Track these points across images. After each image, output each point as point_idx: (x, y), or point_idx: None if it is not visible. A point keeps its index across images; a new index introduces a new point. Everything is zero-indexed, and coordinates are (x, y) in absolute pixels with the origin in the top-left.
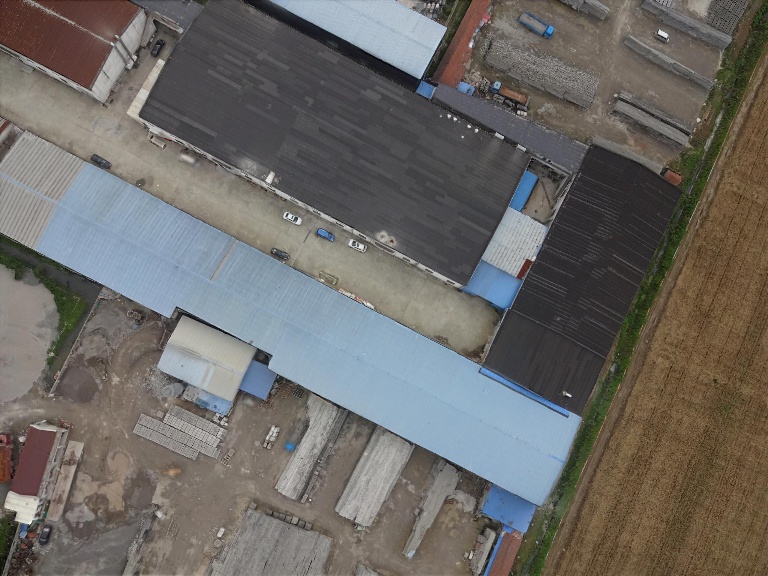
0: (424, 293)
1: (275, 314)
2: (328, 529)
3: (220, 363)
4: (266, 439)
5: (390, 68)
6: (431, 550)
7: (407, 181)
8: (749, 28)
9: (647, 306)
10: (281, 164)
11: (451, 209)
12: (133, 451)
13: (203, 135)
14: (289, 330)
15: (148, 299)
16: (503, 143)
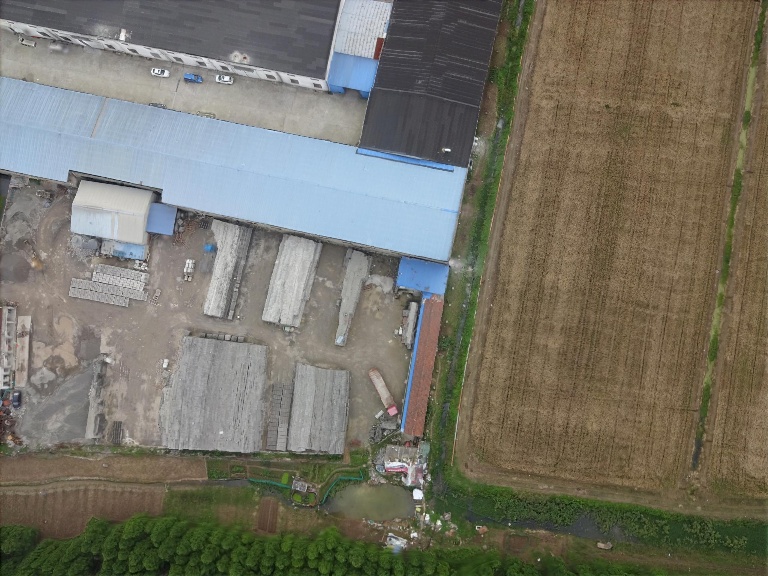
0: (297, 105)
1: (154, 151)
2: (261, 339)
3: (121, 211)
4: (184, 272)
5: None
6: (361, 335)
7: None
8: None
9: (517, 54)
10: (128, 20)
11: (290, 11)
12: (73, 312)
13: (55, 16)
14: (170, 162)
15: (44, 170)
16: None
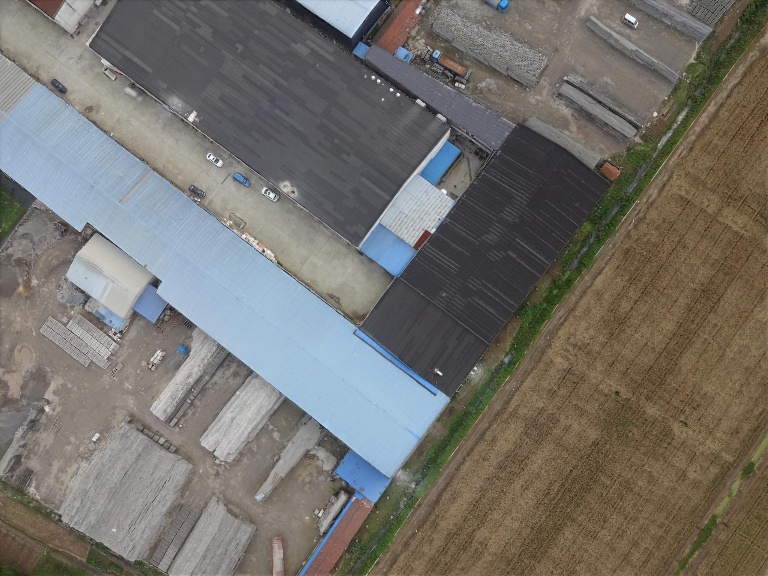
0: (325, 250)
1: (170, 243)
2: (191, 456)
3: (117, 281)
4: (150, 360)
5: (326, 25)
6: (283, 499)
7: (317, 135)
8: (736, 21)
9: (555, 301)
10: (204, 105)
11: (355, 168)
12: (37, 348)
13: (140, 70)
14: (180, 260)
15: (65, 212)
16: (424, 111)
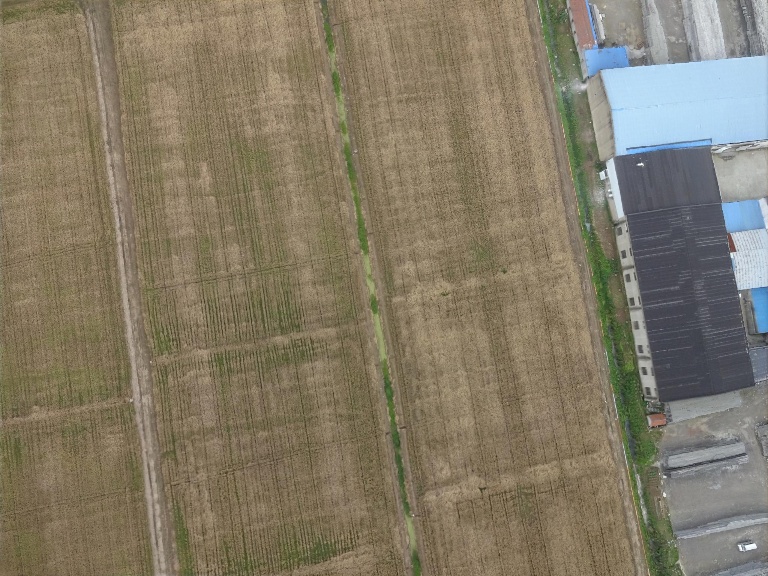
0: (764, 184)
1: None
2: None
3: None
4: None
5: None
6: (630, 5)
7: None
8: None
9: None
10: None
11: None
12: None
13: None
14: None
15: None
16: None
